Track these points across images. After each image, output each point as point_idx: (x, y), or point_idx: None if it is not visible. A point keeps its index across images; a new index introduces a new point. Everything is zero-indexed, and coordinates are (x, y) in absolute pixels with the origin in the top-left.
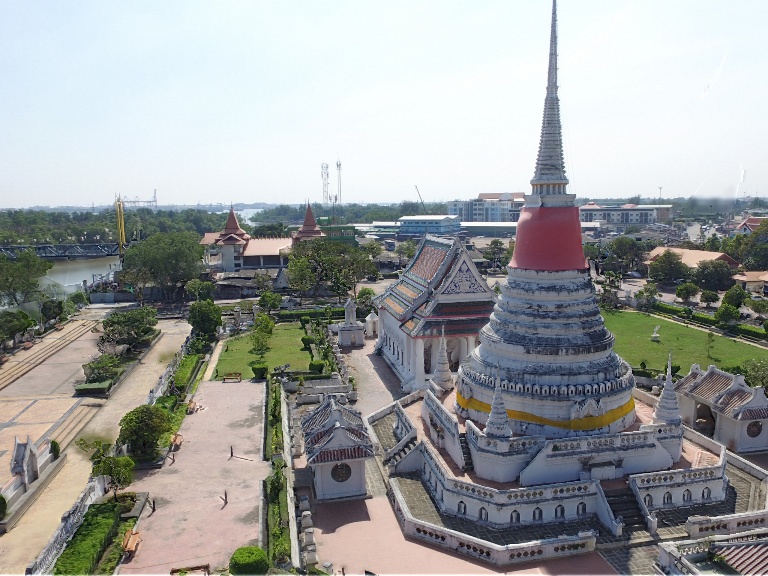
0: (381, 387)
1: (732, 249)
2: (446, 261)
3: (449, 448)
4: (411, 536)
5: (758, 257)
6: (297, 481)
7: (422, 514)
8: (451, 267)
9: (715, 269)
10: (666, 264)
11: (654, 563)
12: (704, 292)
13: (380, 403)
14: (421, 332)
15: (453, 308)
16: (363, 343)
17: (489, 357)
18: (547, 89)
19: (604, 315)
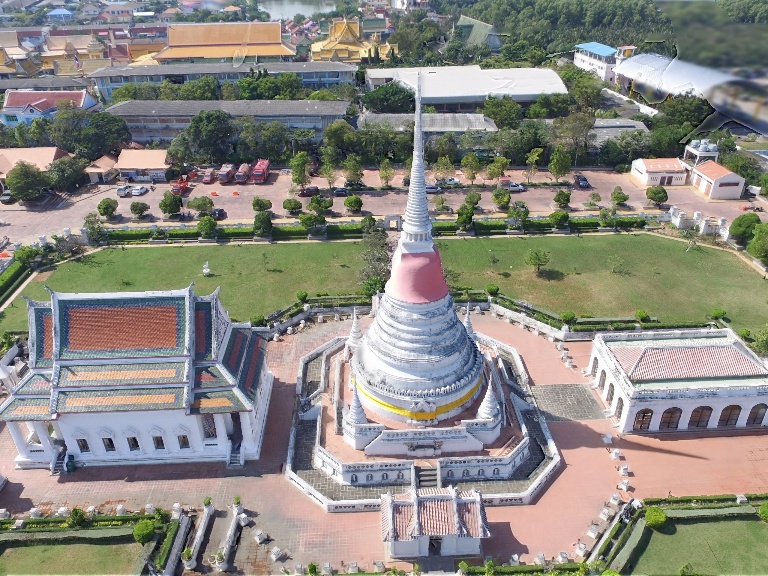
0: (210, 483)
1: (37, 136)
2: (192, 317)
3: (454, 448)
4: (532, 501)
5: (87, 144)
6: (446, 569)
7: (509, 489)
8: (206, 320)
9: (72, 169)
10: (32, 180)
11: (631, 400)
12: (134, 205)
13: (264, 490)
14: (250, 400)
15: (232, 358)
16: (4, 479)
17: (434, 374)
18: (419, 156)
19: (93, 268)
